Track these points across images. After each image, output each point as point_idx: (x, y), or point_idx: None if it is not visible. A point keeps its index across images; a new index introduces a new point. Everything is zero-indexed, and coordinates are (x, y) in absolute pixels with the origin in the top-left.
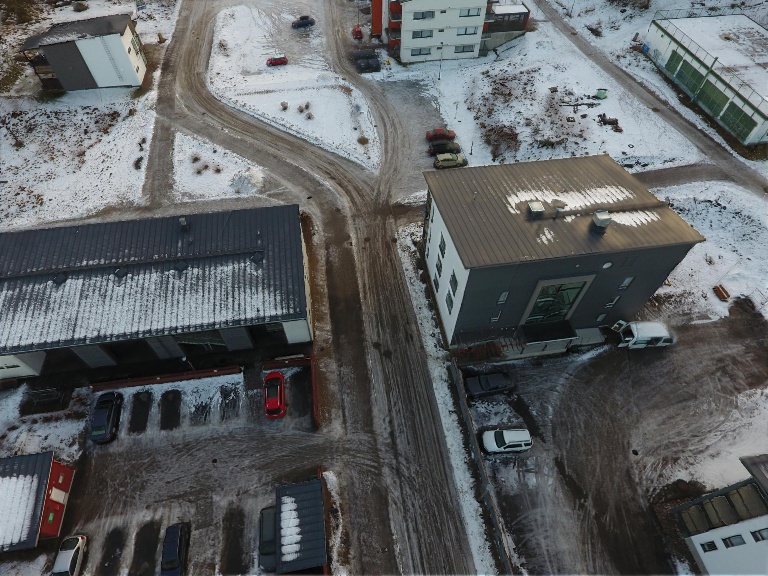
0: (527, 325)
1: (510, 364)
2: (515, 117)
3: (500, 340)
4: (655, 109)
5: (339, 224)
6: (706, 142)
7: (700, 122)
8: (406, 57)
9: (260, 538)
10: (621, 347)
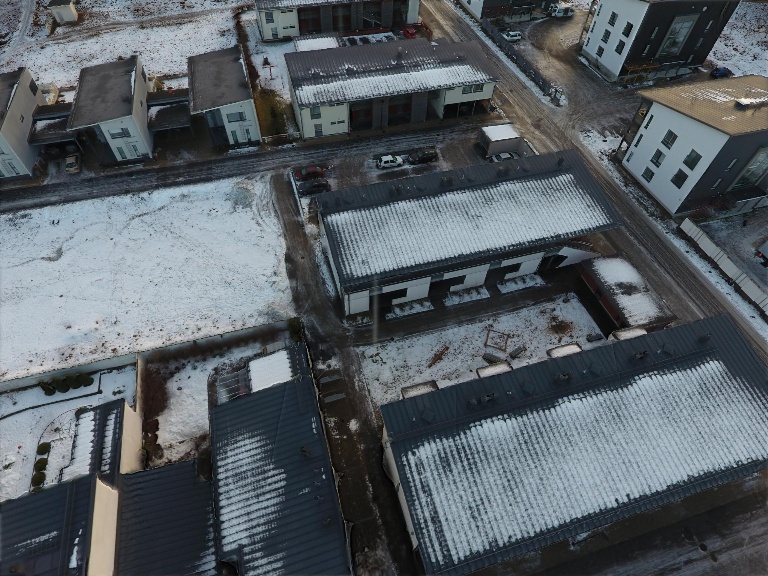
0: (513, 3)
1: None
2: None
3: (501, 17)
4: None
5: None
6: None
7: None
8: None
9: None
10: (553, 17)
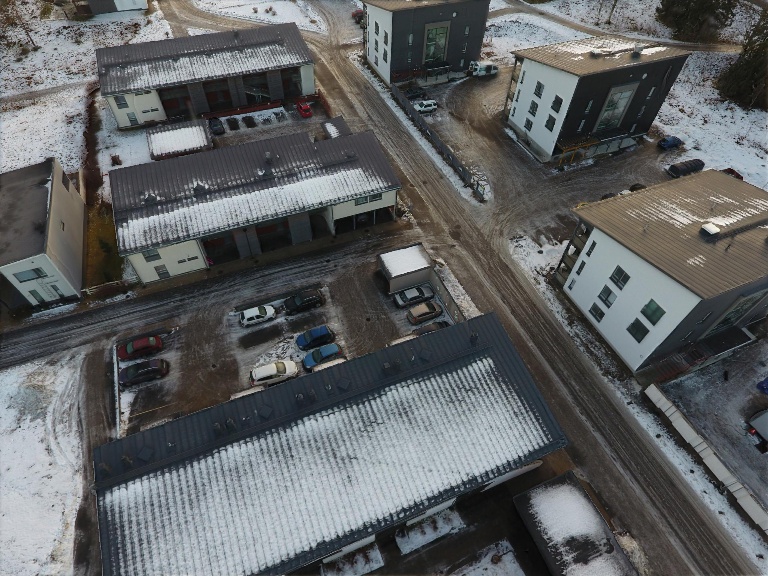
0: (426, 64)
1: None
2: None
3: None
4: None
5: None
6: None
7: None
8: None
9: None
10: (475, 76)
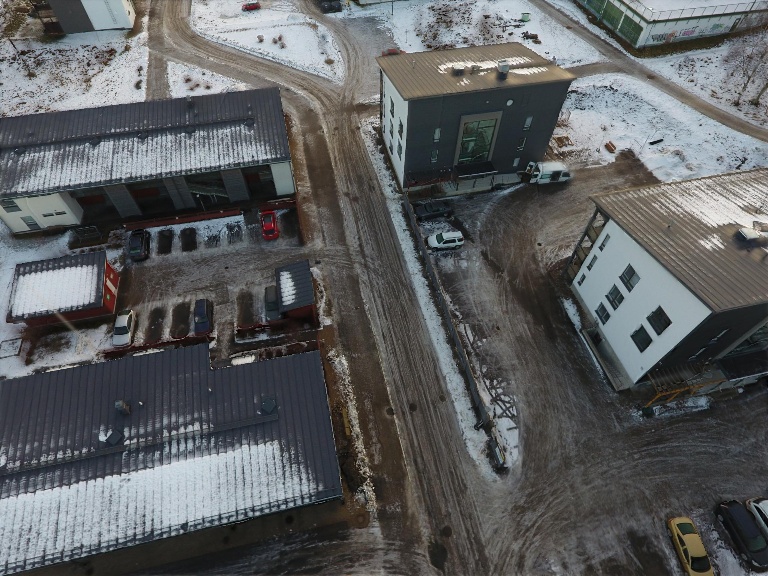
0: (459, 165)
1: (449, 199)
2: (455, 38)
3: (441, 183)
4: (569, 27)
5: (313, 119)
6: (606, 48)
7: (603, 34)
8: None
9: (266, 302)
10: (533, 183)
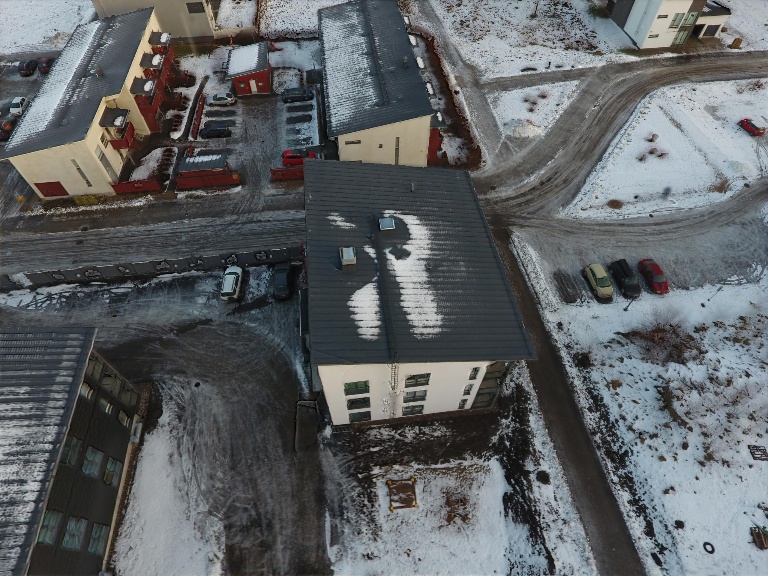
0: None
1: None
2: (731, 367)
3: None
4: None
5: None
6: None
7: None
8: None
9: None
10: None
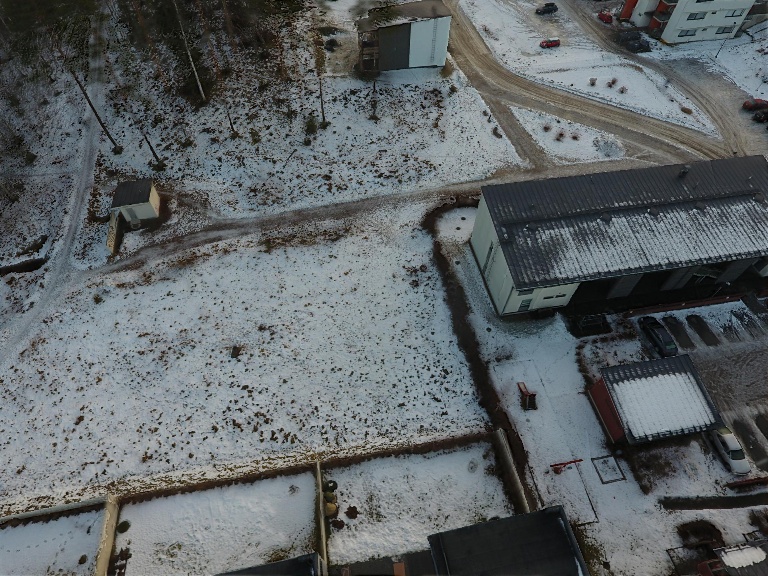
0: None
1: None
2: None
3: None
4: None
5: None
6: None
7: None
8: (673, 38)
9: None
10: None
